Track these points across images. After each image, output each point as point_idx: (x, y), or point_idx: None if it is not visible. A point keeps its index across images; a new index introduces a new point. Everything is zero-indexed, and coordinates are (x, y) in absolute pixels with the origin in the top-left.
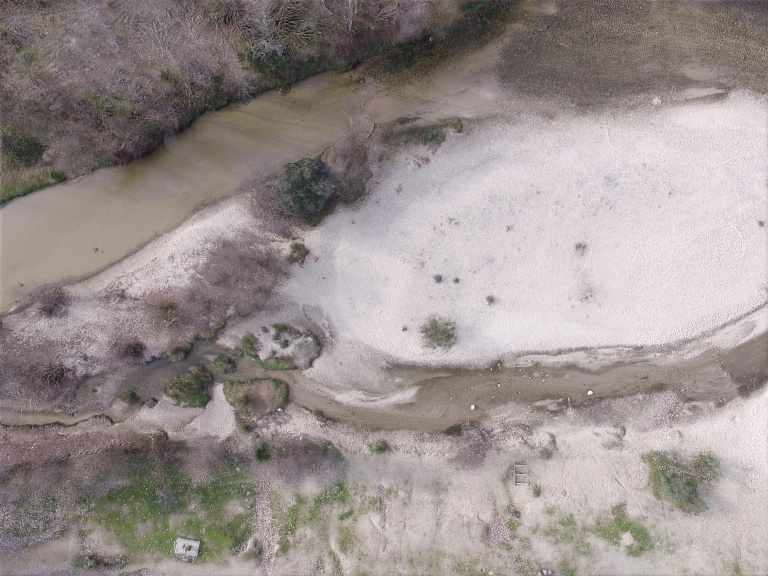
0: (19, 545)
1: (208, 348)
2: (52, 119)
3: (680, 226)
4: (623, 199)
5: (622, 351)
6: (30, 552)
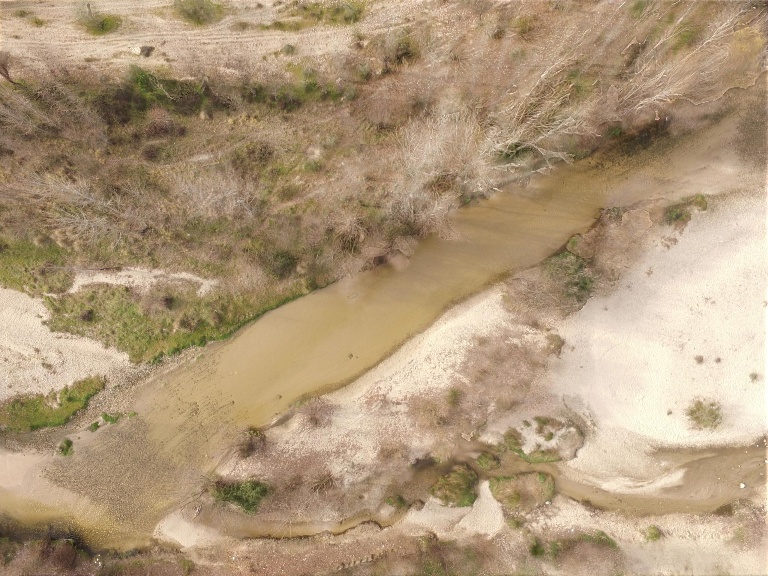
0: None
1: (470, 446)
2: (302, 231)
3: None
4: None
5: None
6: None
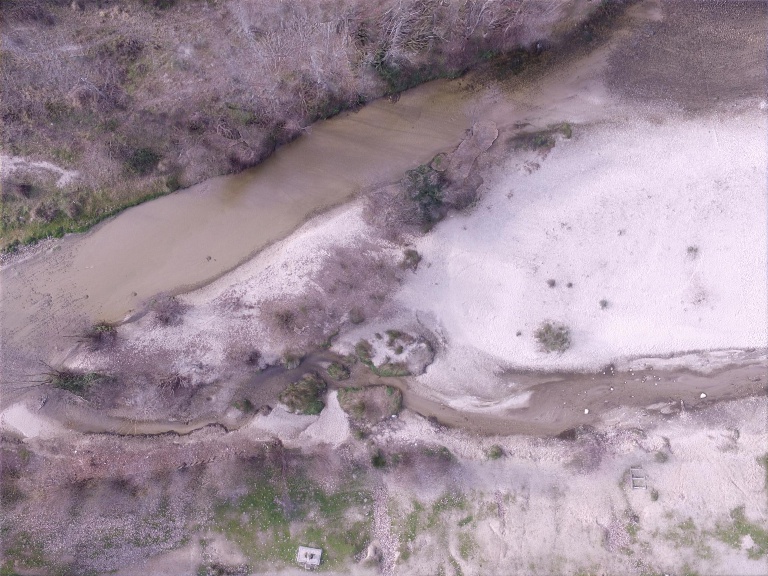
0: (140, 555)
1: (321, 355)
2: (167, 129)
3: None
4: (734, 202)
5: (734, 354)
6: (152, 562)
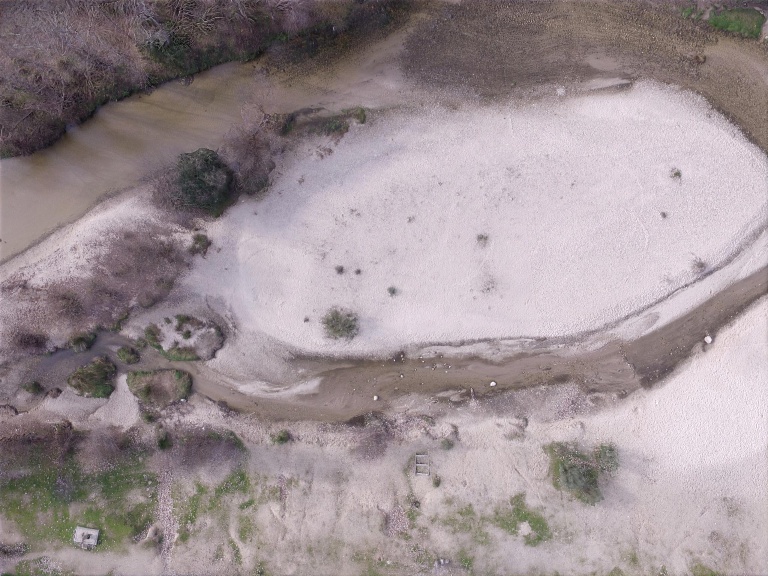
0: None
1: (112, 339)
2: None
3: (582, 217)
4: (525, 190)
5: (525, 342)
6: None
